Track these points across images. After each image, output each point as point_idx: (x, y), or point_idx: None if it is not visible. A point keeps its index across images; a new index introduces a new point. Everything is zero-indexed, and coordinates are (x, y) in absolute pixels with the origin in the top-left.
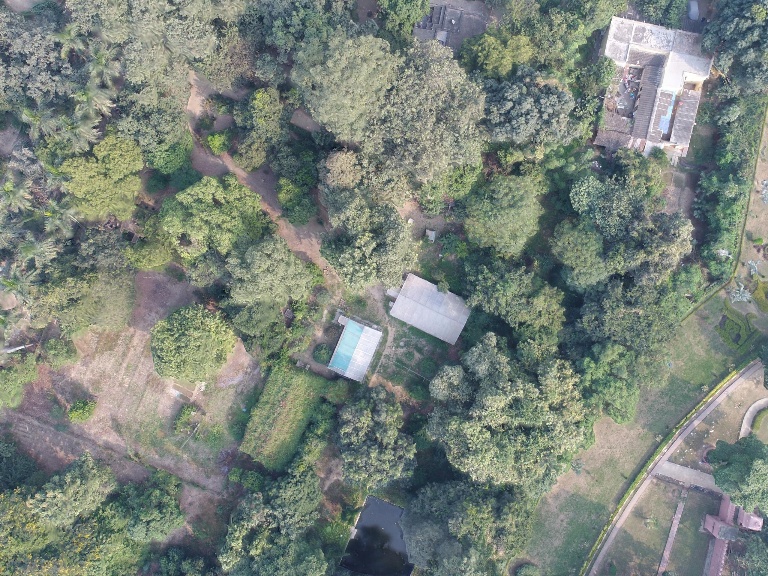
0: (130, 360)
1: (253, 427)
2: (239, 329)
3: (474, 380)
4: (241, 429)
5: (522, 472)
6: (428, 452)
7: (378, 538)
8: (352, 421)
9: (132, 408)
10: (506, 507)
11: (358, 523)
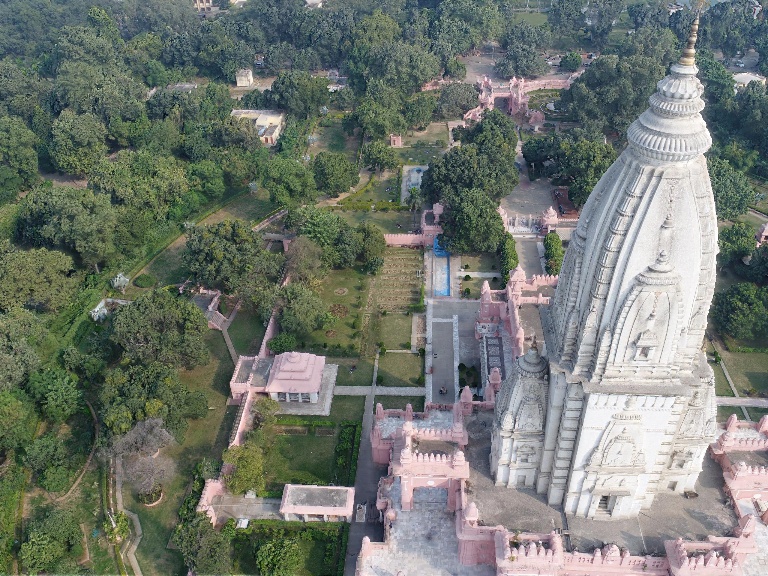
0: None
1: None
2: None
3: None
4: None
5: None
6: None
7: None
8: None
9: None
10: None
11: None
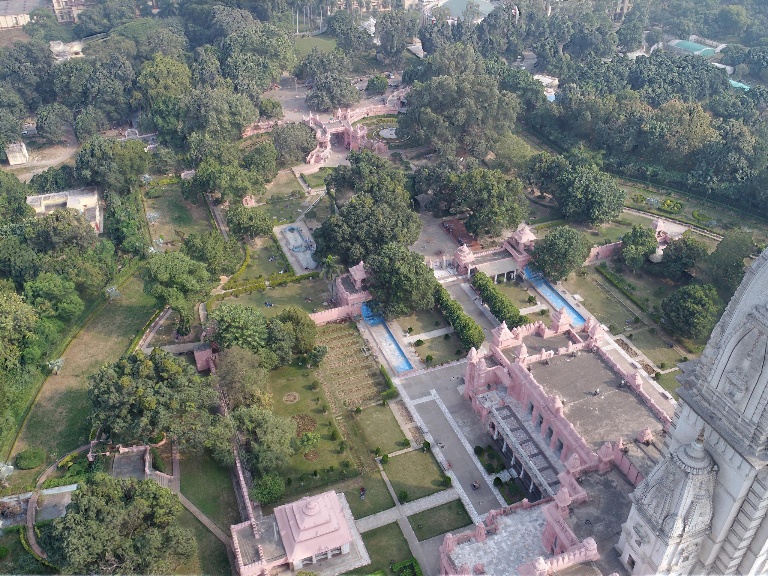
0: None
1: None
2: None
3: None
4: None
5: None
6: None
7: None
8: None
9: None
10: None
11: None
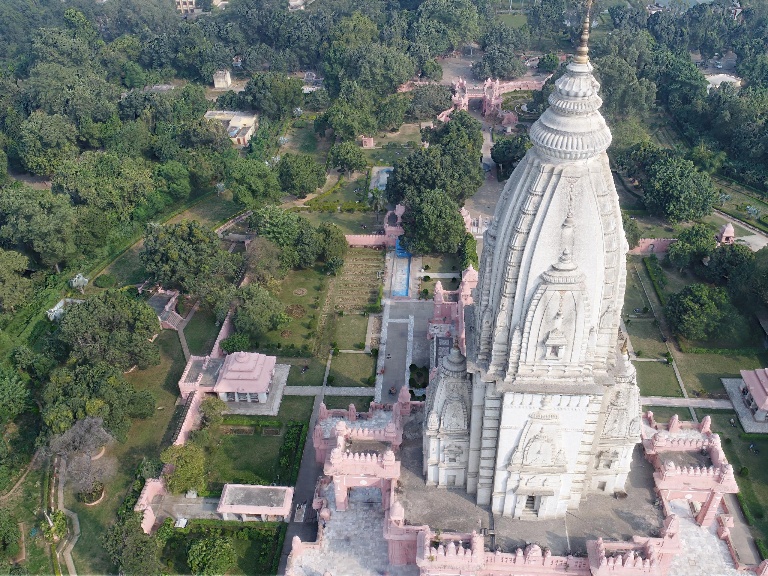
0: None
1: None
2: None
3: None
4: None
5: None
6: None
7: None
8: None
9: None
10: None
11: None
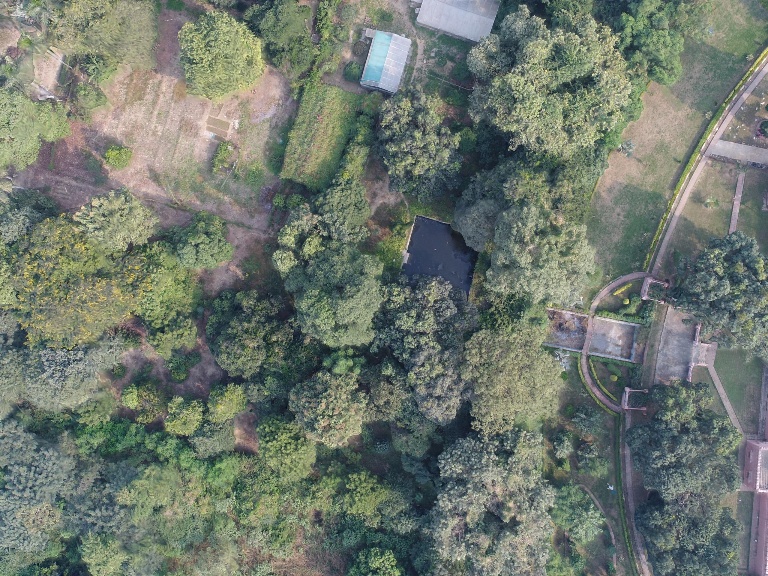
0: (161, 107)
1: (292, 150)
2: (266, 49)
3: (512, 52)
4: (280, 161)
5: (573, 131)
6: (472, 161)
7: (431, 260)
8: (392, 110)
9: (168, 156)
10: (560, 174)
11: (409, 247)
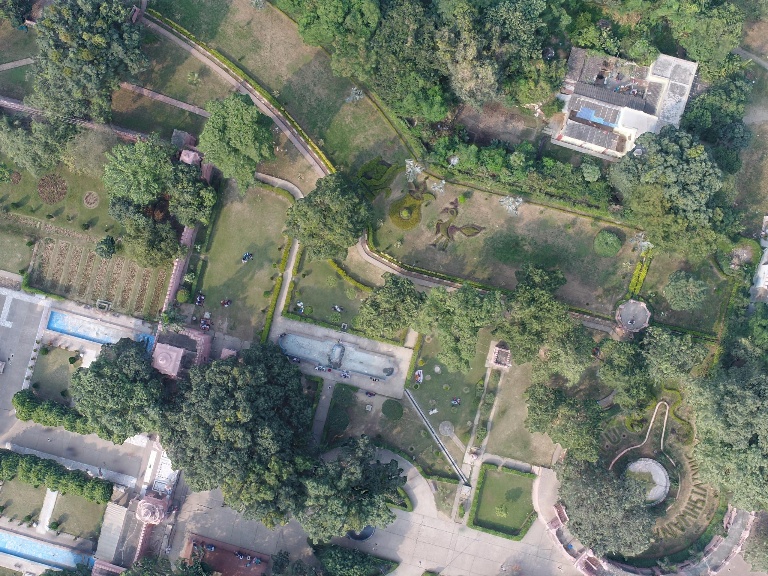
0: None
1: None
2: None
3: None
4: None
5: None
6: None
7: None
8: None
9: None
10: None
11: None
